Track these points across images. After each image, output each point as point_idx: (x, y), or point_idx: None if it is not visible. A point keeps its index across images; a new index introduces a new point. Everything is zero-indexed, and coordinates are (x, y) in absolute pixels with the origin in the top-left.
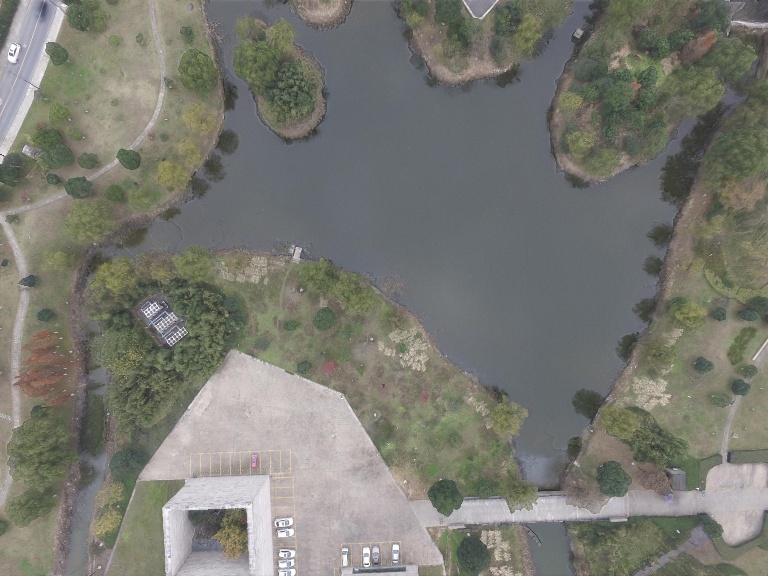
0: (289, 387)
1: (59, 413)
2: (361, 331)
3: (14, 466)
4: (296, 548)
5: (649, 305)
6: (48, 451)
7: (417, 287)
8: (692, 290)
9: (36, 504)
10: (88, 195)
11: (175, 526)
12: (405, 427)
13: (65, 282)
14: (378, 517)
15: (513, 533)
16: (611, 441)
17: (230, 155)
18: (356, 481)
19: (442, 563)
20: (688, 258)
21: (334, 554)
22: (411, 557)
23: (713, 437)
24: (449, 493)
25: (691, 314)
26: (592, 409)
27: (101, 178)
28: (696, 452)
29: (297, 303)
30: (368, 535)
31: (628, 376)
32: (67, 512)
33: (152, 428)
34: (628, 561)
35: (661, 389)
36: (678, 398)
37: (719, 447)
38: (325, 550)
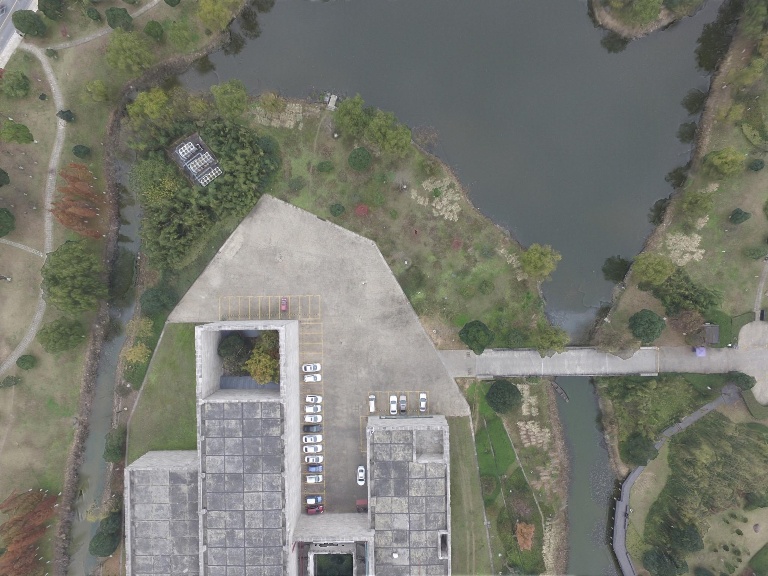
0: (321, 233)
1: (92, 245)
2: (394, 179)
3: (47, 289)
4: (323, 395)
5: (682, 171)
6: (81, 276)
7: (451, 140)
8: (729, 146)
9: (67, 331)
10: (128, 28)
11: (206, 351)
12: (436, 276)
13: (101, 123)
14: (406, 366)
15: (541, 388)
16: (643, 296)
17: (266, 13)
18: (385, 329)
19: (469, 414)
20: (727, 105)
21: (361, 402)
22: (438, 407)
23: (746, 294)
24: (481, 328)
25: (730, 157)
26: (622, 274)
27: (140, 17)
28: (729, 309)
29: (331, 149)
30: (395, 384)
31: (661, 233)
32: (95, 354)
33: (183, 270)
34: (657, 418)
35: (695, 244)
36: (712, 253)
37: (752, 305)
38: (352, 398)
